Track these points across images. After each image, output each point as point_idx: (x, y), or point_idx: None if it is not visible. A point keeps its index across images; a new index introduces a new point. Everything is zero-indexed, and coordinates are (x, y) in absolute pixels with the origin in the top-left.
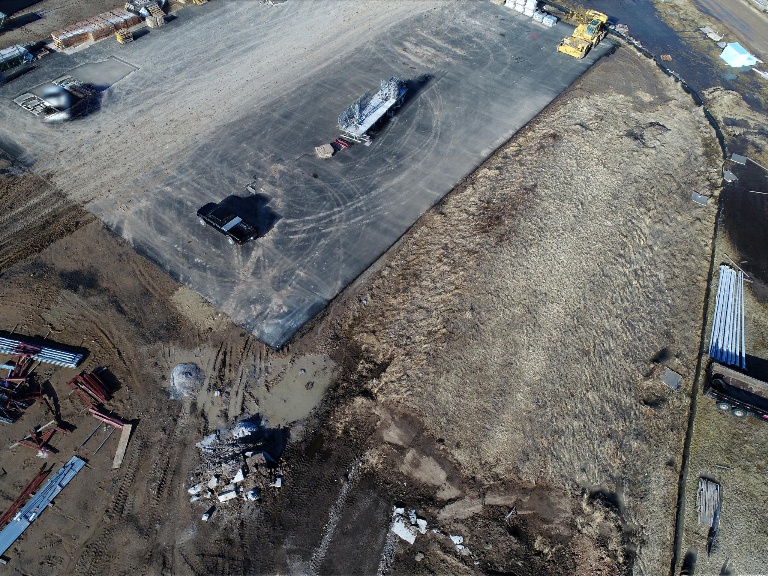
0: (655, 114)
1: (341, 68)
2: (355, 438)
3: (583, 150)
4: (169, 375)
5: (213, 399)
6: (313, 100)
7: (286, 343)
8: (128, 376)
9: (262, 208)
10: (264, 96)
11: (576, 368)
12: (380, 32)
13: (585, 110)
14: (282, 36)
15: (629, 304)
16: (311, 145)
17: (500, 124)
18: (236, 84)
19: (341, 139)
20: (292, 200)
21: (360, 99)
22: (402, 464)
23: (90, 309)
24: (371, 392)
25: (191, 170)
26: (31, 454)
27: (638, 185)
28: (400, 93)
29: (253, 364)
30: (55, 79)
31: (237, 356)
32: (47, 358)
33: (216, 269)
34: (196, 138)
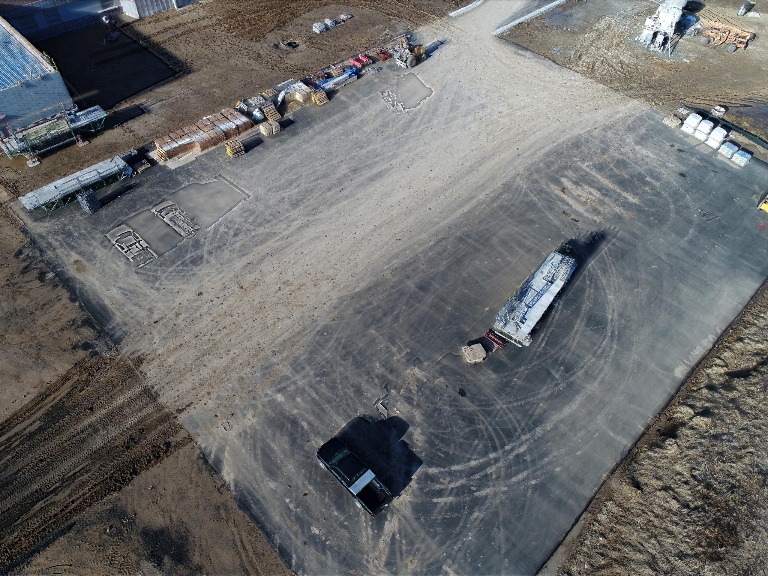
0: None
1: (487, 214)
2: None
3: None
4: None
5: None
6: (455, 263)
7: None
8: None
9: (396, 443)
10: (396, 252)
11: None
12: (532, 161)
13: None
14: (415, 159)
15: None
16: (455, 339)
17: (695, 323)
18: (362, 230)
19: (493, 332)
20: (434, 433)
21: (522, 284)
22: None
23: None
24: None
25: (308, 368)
26: None
27: None
28: None
29: None
30: (155, 206)
31: None
32: None
33: (338, 550)
34: (315, 314)
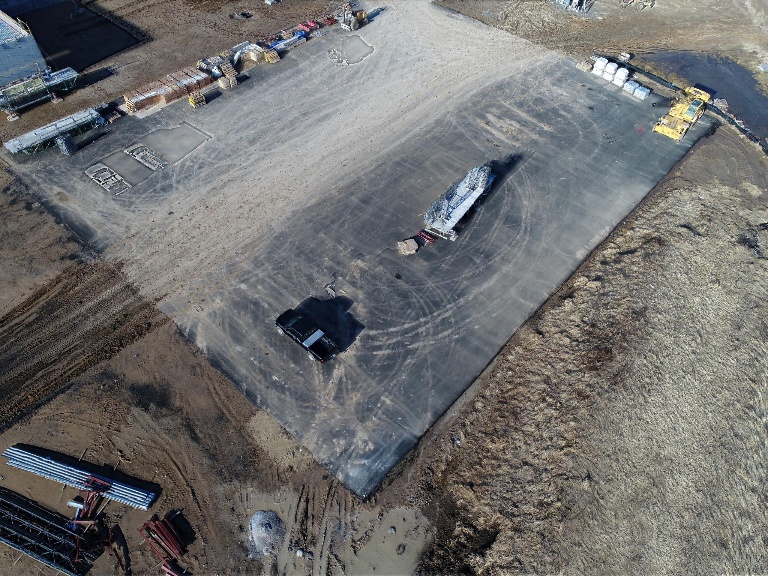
0: (766, 213)
1: (421, 144)
2: None
3: (693, 261)
4: (247, 525)
5: (295, 561)
6: (393, 182)
7: (373, 491)
8: (203, 524)
9: (343, 315)
10: (341, 175)
11: (715, 566)
12: (461, 101)
13: (689, 206)
14: (358, 103)
15: (763, 470)
16: (393, 238)
17: (595, 218)
18: (312, 160)
19: (424, 231)
20: (375, 306)
21: (447, 189)
22: None
23: (162, 434)
24: (474, 572)
25: (267, 264)
26: None
27: (760, 310)
28: (488, 181)
29: (338, 517)
30: (127, 147)
31: (320, 505)
32: (117, 497)
33: (295, 390)
34: (272, 225)
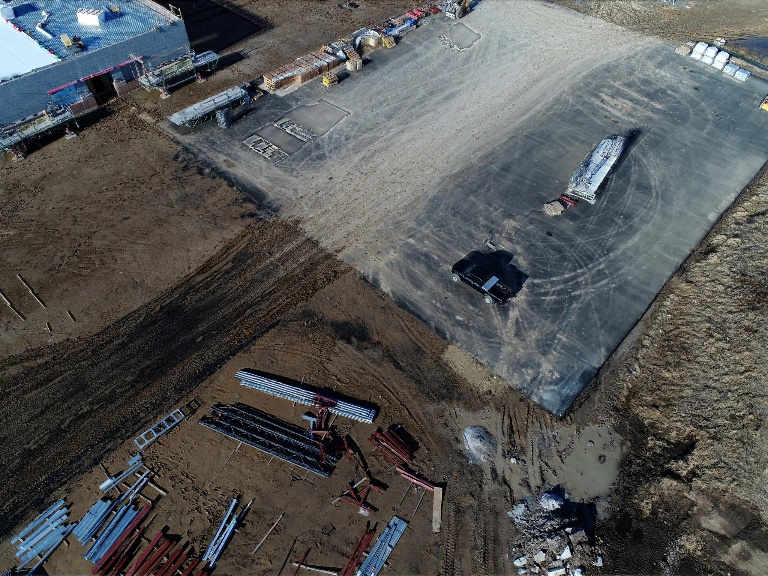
0: None
1: (545, 119)
2: (665, 520)
3: None
4: (461, 437)
5: (511, 466)
6: (526, 153)
7: (567, 412)
8: (423, 436)
9: (506, 266)
10: (478, 147)
11: None
12: (573, 82)
13: None
14: (478, 83)
15: None
16: (537, 201)
17: (719, 186)
18: (447, 133)
19: (565, 196)
20: (534, 259)
21: (586, 157)
22: (725, 554)
23: (368, 363)
24: (679, 474)
25: (428, 222)
26: (353, 510)
27: None
28: (619, 151)
29: (540, 432)
30: (275, 122)
31: (522, 422)
32: (344, 412)
33: (479, 328)
34: (424, 189)
